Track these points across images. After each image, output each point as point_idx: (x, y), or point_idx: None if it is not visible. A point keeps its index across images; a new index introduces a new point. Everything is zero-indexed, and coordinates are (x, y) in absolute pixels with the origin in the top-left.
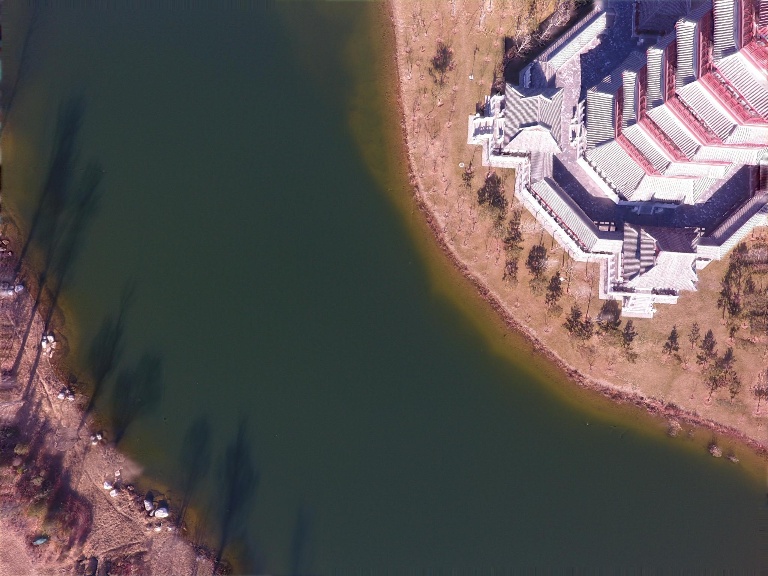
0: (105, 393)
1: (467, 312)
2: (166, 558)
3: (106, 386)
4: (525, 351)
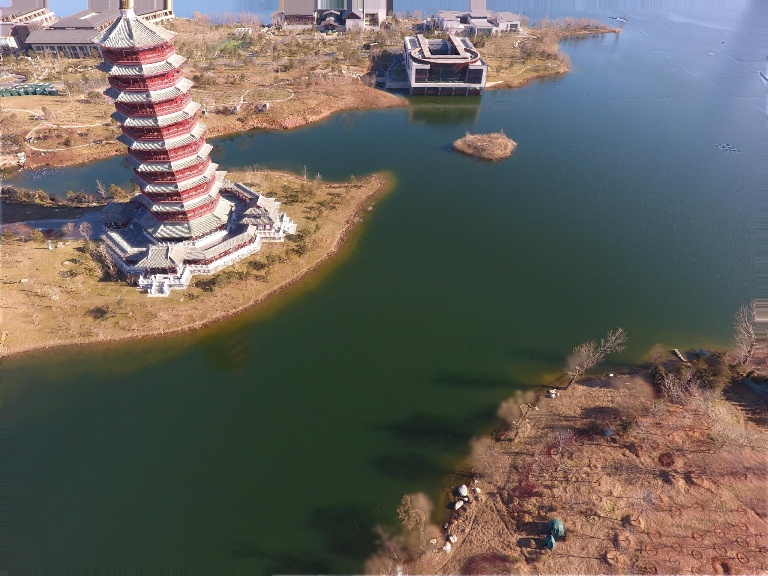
0: (352, 570)
1: (288, 301)
2: (501, 478)
3: (343, 568)
4: (315, 274)
